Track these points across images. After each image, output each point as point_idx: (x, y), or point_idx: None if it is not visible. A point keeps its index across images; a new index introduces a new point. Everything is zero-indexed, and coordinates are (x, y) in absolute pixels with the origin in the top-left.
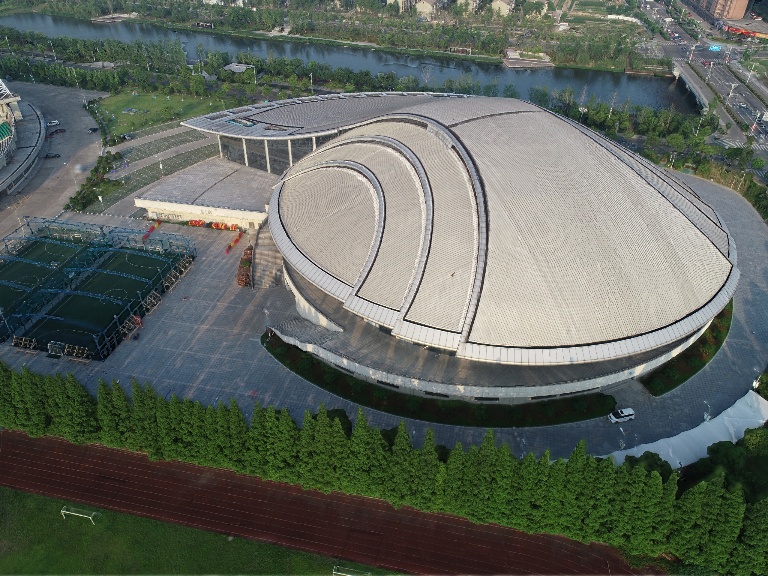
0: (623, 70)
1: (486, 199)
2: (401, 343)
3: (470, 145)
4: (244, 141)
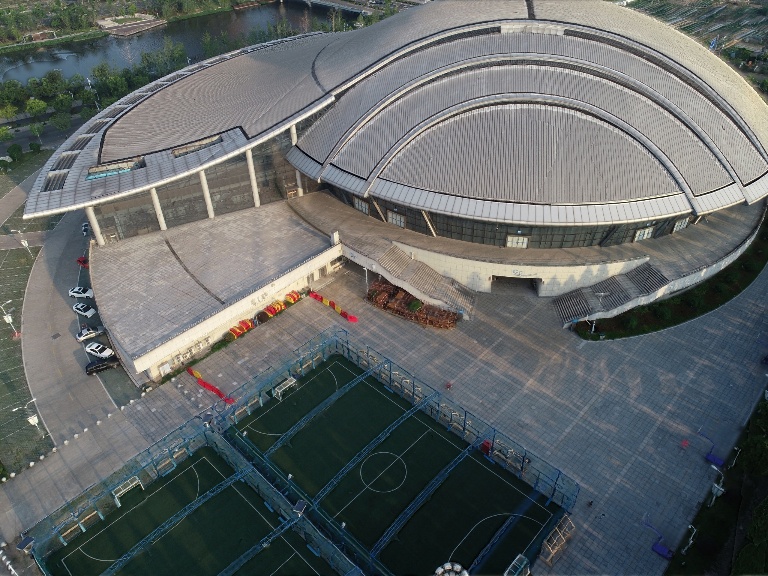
0: (231, 7)
1: (668, 56)
2: (681, 233)
3: (583, 23)
4: (154, 191)
